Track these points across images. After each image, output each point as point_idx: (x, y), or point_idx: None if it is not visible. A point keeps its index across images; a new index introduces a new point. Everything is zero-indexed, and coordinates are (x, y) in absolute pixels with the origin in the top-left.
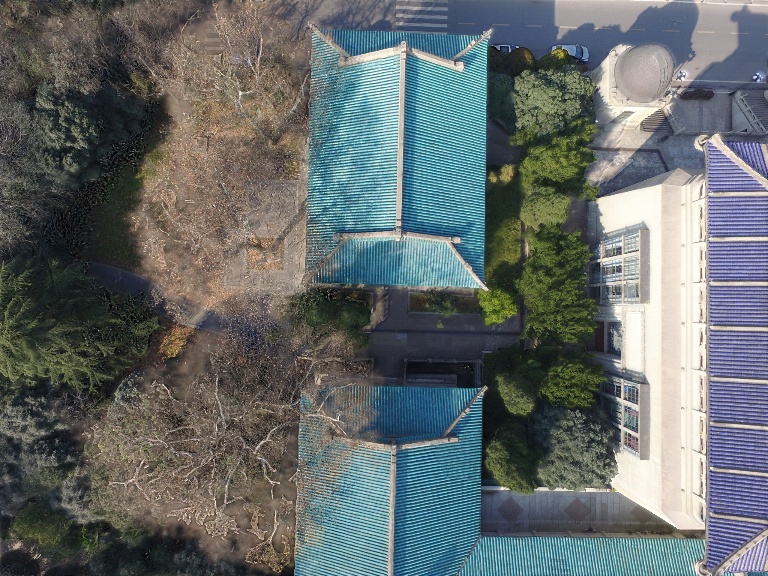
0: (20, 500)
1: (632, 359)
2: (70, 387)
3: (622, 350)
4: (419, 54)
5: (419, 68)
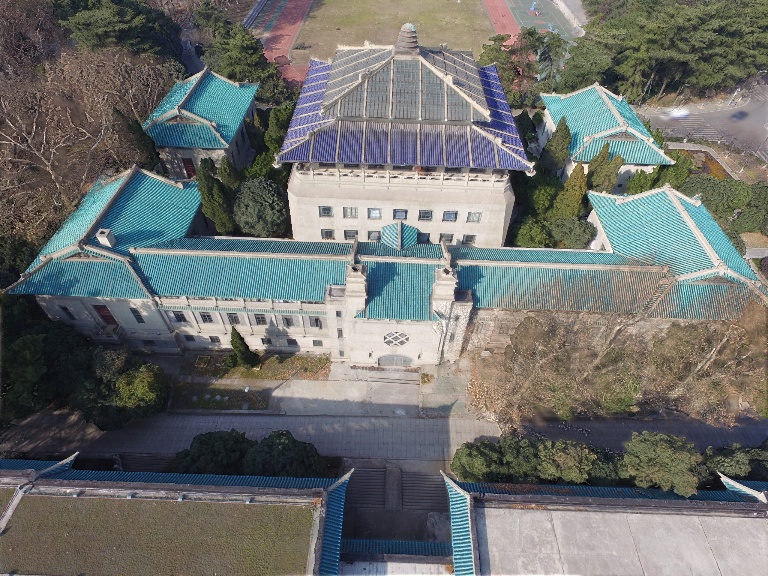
0: None
1: None
2: None
3: None
4: (214, 73)
5: (214, 78)
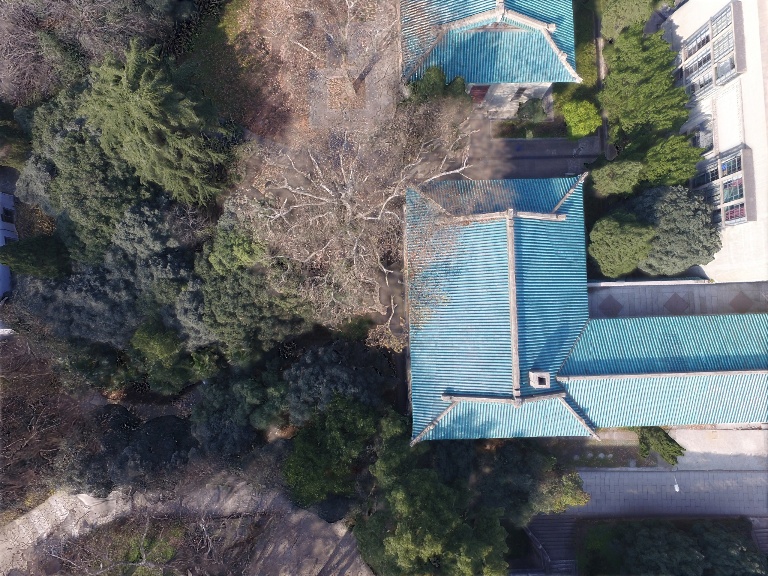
0: (133, 323)
1: (727, 139)
2: (180, 203)
3: (714, 138)
4: None
5: None
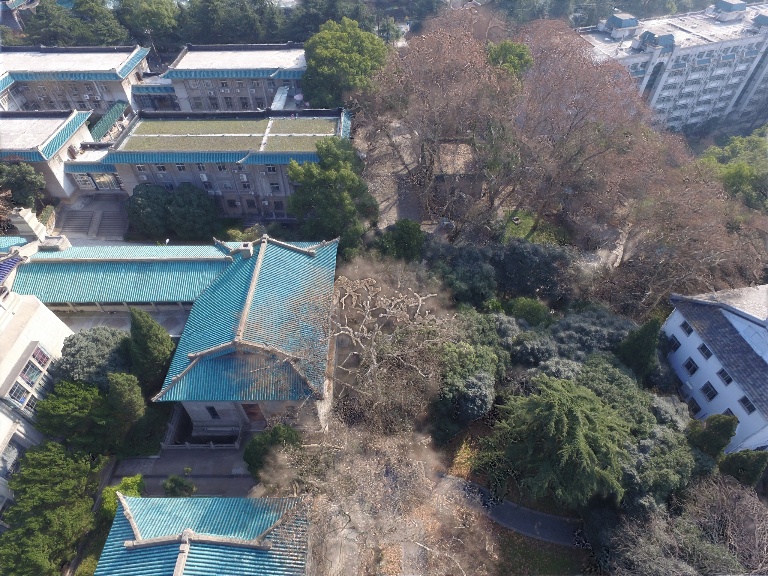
0: None
1: (1, 427)
2: None
3: (8, 441)
4: None
5: None
